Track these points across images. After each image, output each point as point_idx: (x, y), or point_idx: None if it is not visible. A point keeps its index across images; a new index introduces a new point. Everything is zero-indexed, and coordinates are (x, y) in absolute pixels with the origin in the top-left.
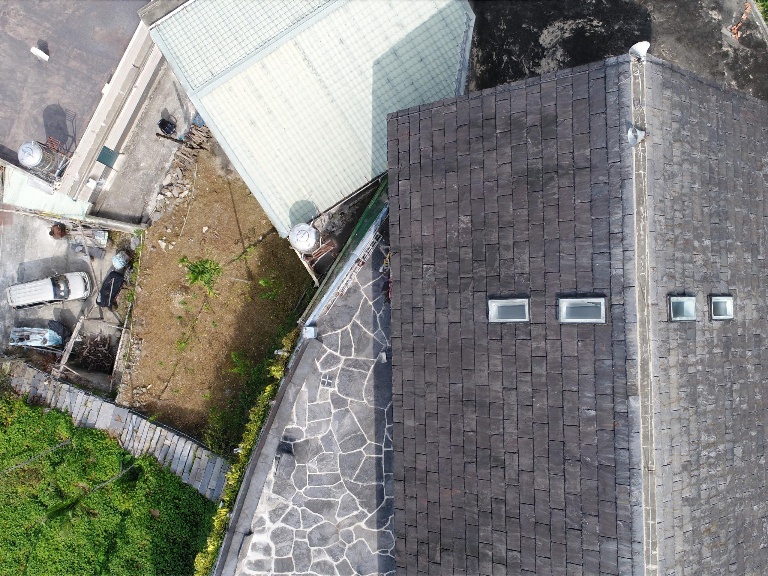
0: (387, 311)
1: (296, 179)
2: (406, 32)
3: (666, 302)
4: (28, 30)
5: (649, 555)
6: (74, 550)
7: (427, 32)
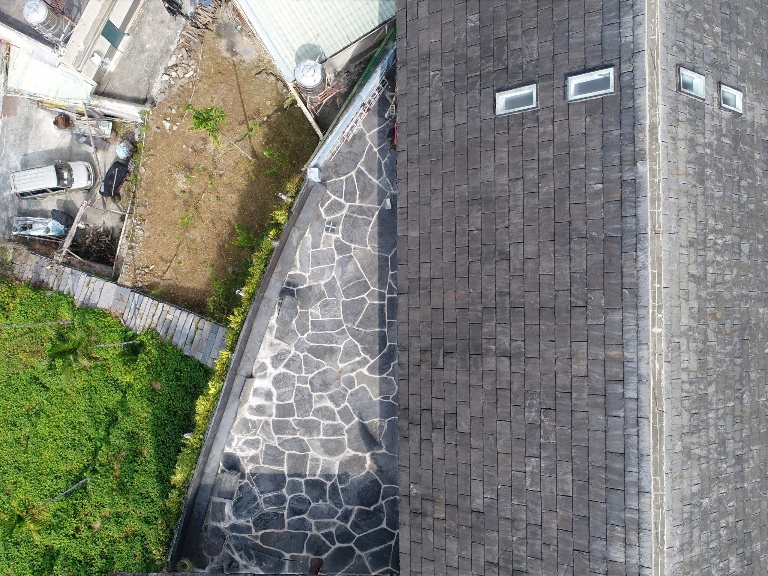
0: (392, 158)
1: (302, 21)
2: None
3: (676, 72)
4: None
5: (654, 318)
6: (75, 427)
7: None
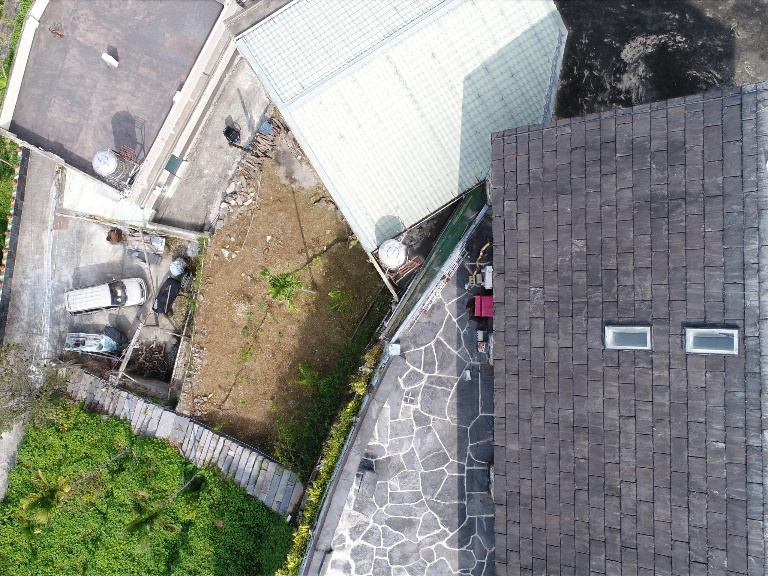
0: (471, 328)
1: (383, 194)
2: (498, 47)
3: None
4: (98, 36)
5: None
6: (134, 559)
7: (519, 47)
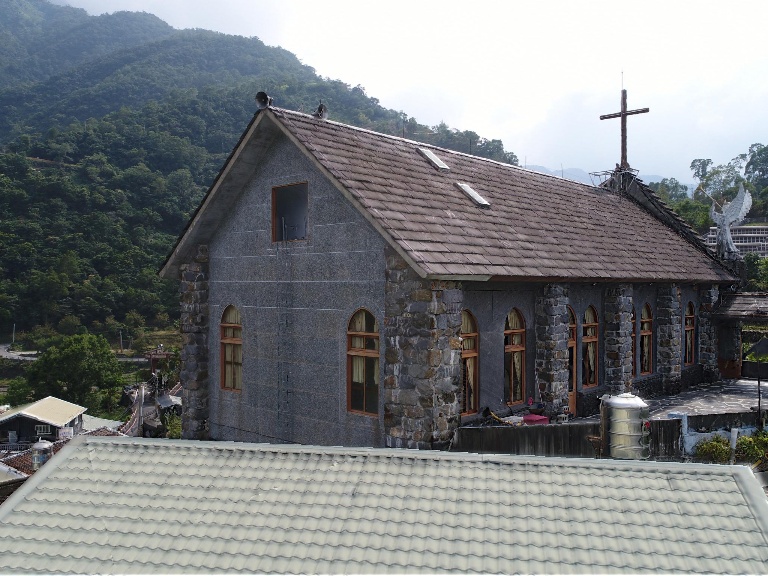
0: None
1: None
2: None
3: None
4: None
5: None
6: None
7: None
